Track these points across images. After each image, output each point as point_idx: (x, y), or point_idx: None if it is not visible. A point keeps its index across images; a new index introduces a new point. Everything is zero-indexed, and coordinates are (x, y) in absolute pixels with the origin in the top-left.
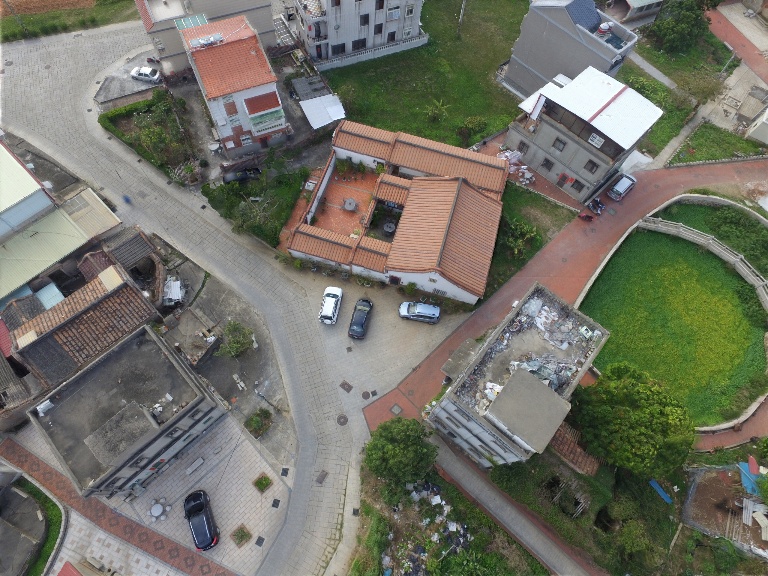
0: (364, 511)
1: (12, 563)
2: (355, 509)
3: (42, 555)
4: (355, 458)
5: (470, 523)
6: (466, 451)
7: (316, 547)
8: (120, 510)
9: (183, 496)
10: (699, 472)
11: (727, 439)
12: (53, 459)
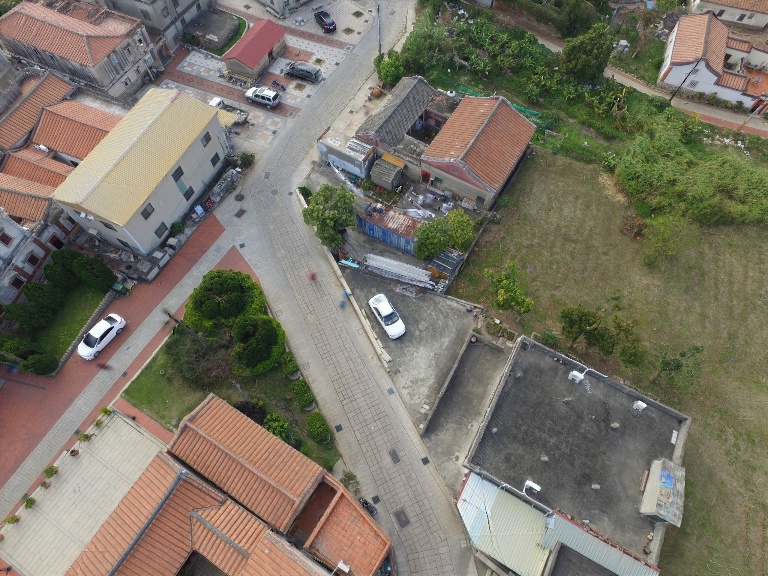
0: (418, 22)
1: (225, 28)
2: (413, 23)
3: (238, 34)
4: (411, 6)
5: (481, 16)
6: (478, 2)
7: (392, 35)
8: (277, 23)
9: (312, 18)
10: (622, 8)
11: (643, 6)
12: (235, 6)
